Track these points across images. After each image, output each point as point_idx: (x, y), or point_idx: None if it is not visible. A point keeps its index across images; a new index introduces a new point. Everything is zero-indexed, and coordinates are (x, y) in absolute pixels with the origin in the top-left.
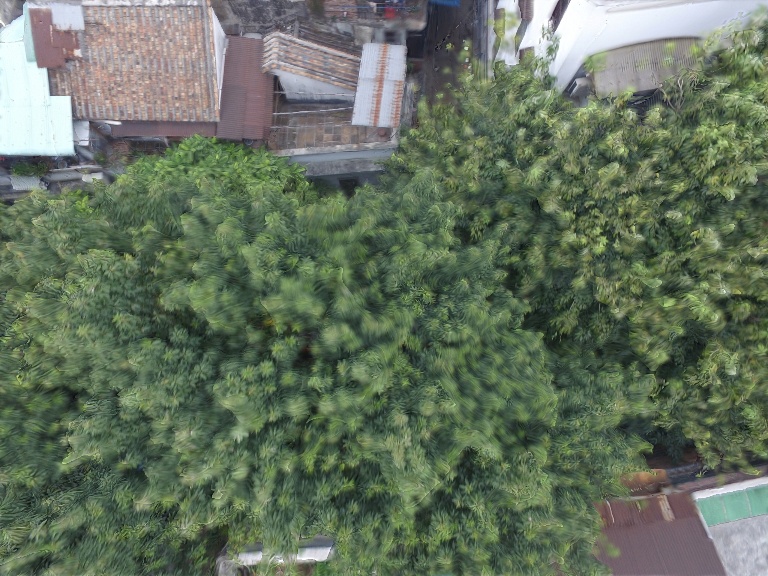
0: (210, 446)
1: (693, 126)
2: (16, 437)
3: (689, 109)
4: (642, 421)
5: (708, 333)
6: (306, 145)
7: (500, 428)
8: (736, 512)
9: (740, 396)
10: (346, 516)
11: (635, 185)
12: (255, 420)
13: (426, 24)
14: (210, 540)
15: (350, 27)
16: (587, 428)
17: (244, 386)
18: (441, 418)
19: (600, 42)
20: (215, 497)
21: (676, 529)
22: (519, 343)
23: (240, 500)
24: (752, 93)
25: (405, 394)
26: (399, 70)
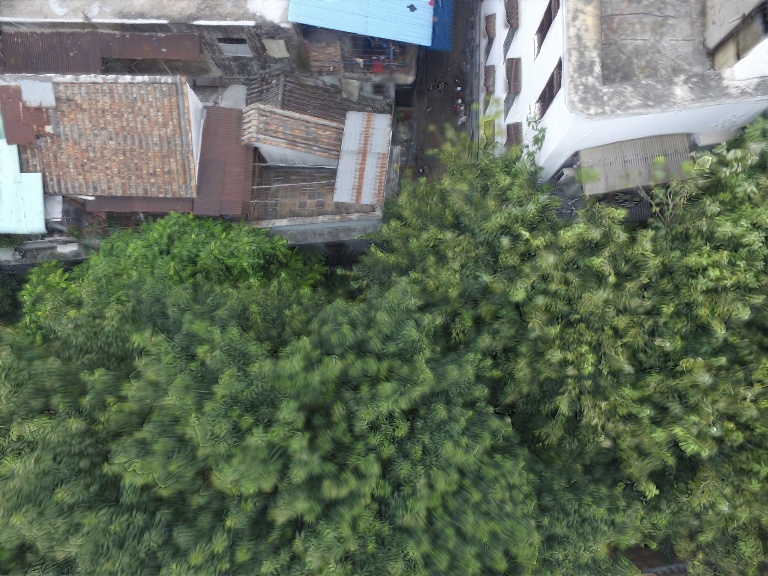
0: None
1: (683, 242)
2: None
3: (679, 225)
4: None
5: (699, 456)
6: (289, 212)
7: (476, 574)
8: None
9: (733, 521)
10: None
11: (622, 301)
12: None
13: (415, 78)
14: None
15: (337, 80)
16: (570, 563)
17: None
18: None
19: (586, 141)
20: None
21: None
22: (498, 473)
23: None
24: (745, 217)
25: (371, 559)
26: (383, 141)
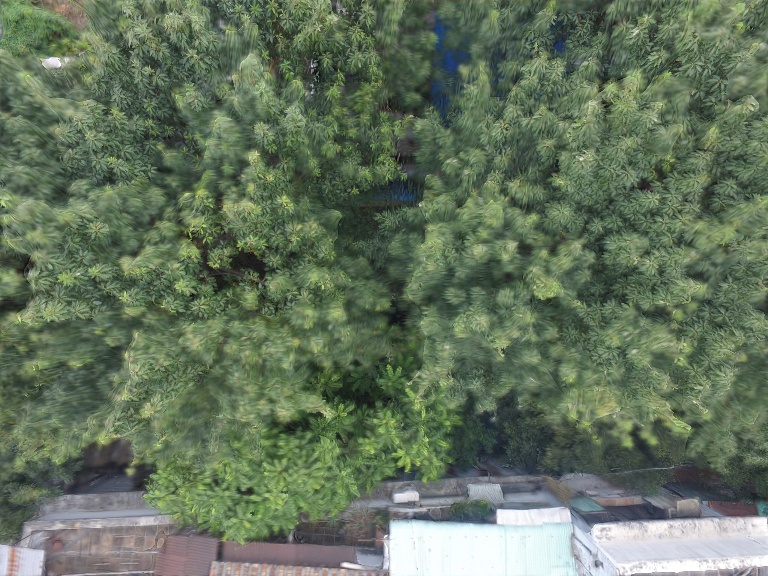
0: None
1: None
2: None
3: None
4: None
5: None
6: (156, 533)
7: None
8: None
9: None
10: None
11: None
12: None
13: None
14: None
15: None
16: None
17: None
18: None
19: None
20: None
21: None
22: None
23: None
24: None
25: None
26: None
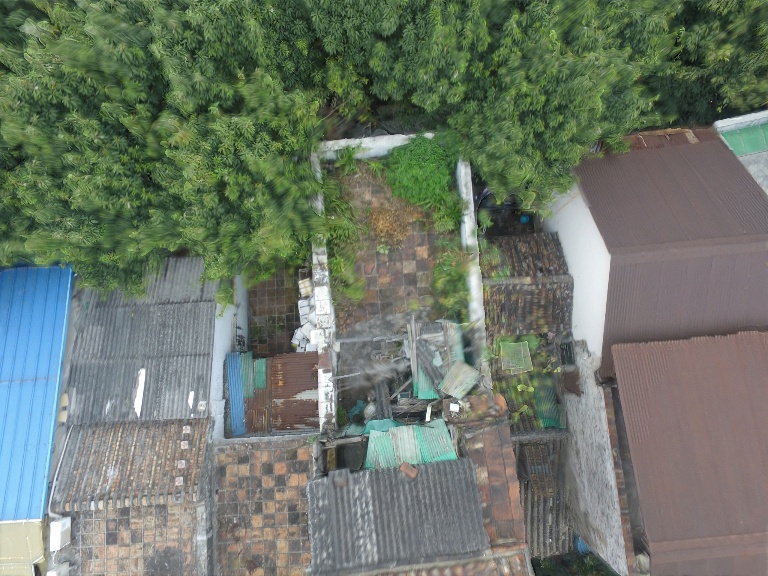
0: None
1: None
2: None
3: None
4: (666, 105)
5: None
6: None
7: None
8: (753, 146)
9: None
10: None
11: None
12: None
13: None
14: (308, 101)
15: None
16: (627, 8)
17: None
18: None
19: None
20: None
21: (701, 148)
22: None
23: None
24: None
25: None
26: None
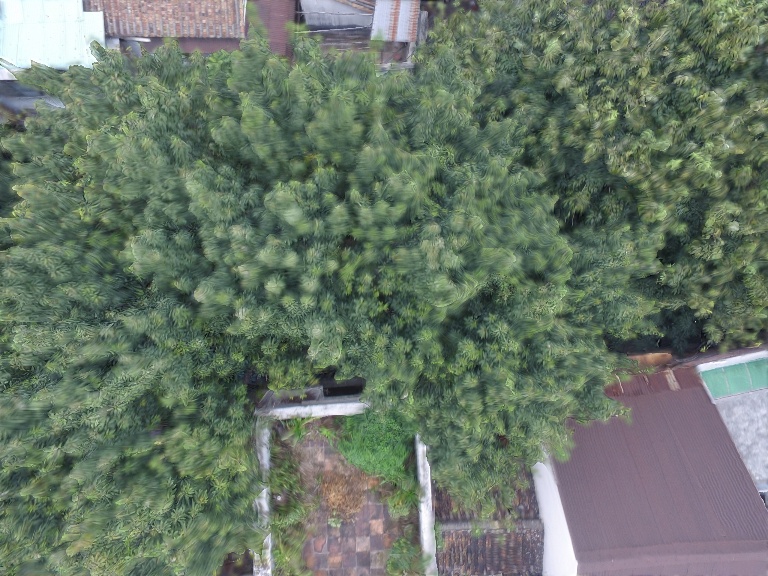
0: (264, 243)
1: (699, 2)
2: (79, 266)
3: None
4: None
5: (712, 201)
6: None
7: (520, 273)
8: (738, 386)
9: (742, 261)
10: (382, 333)
11: (644, 61)
12: (303, 225)
13: None
14: (250, 386)
15: None
16: (600, 284)
17: (294, 193)
18: (469, 241)
19: None
20: (271, 283)
21: (682, 397)
22: (536, 204)
23: (290, 298)
24: None
25: (435, 223)
26: None
